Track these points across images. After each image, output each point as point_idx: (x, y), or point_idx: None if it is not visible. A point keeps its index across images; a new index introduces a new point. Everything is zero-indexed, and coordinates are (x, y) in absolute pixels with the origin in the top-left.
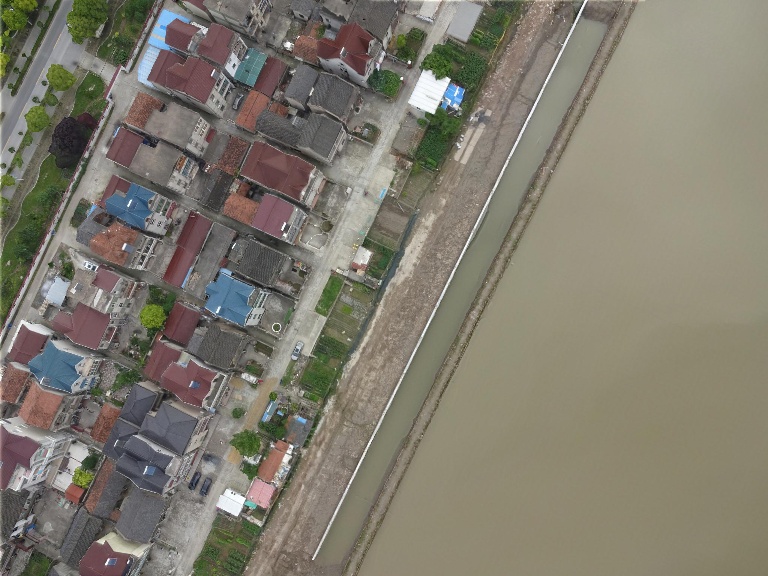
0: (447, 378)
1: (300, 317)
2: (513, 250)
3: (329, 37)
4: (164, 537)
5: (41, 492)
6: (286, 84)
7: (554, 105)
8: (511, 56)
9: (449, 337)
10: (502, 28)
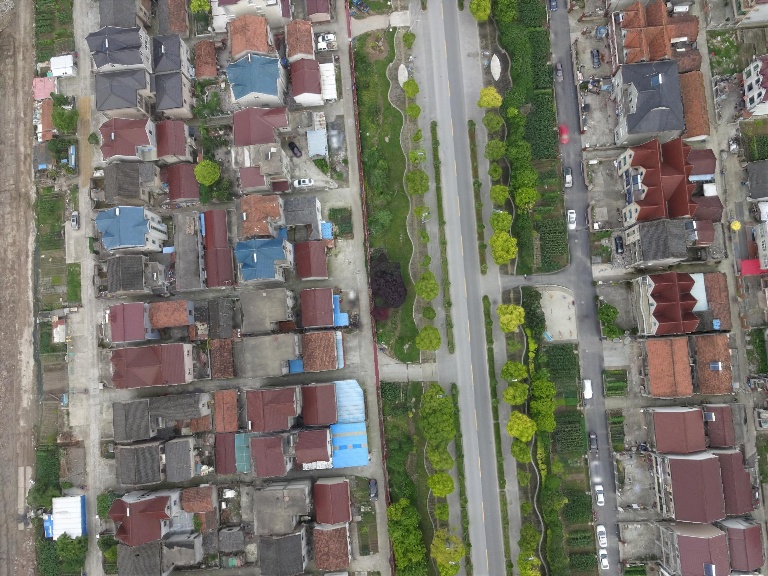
0: None
1: None
2: None
3: (187, 522)
4: None
5: None
6: None
7: None
8: None
9: None
10: None
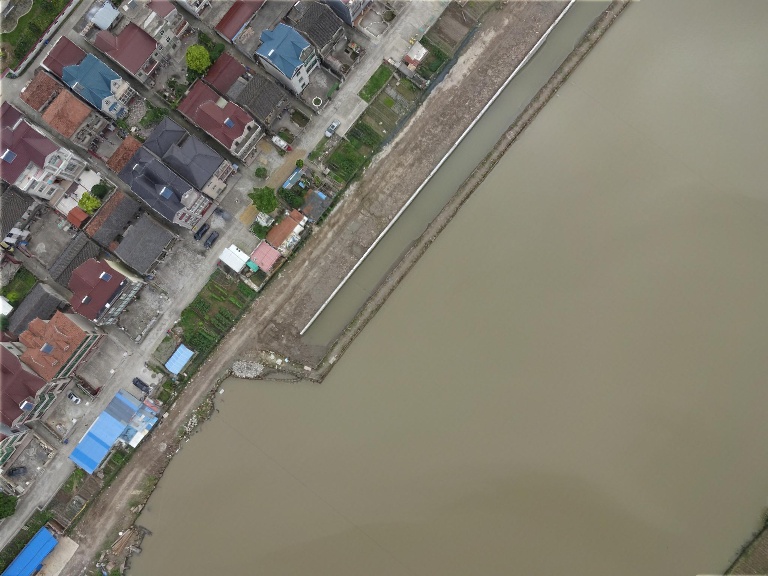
0: (471, 189)
1: (342, 97)
2: (562, 82)
3: None
4: (158, 280)
5: (43, 209)
6: None
7: None
8: None
9: (480, 155)
10: None
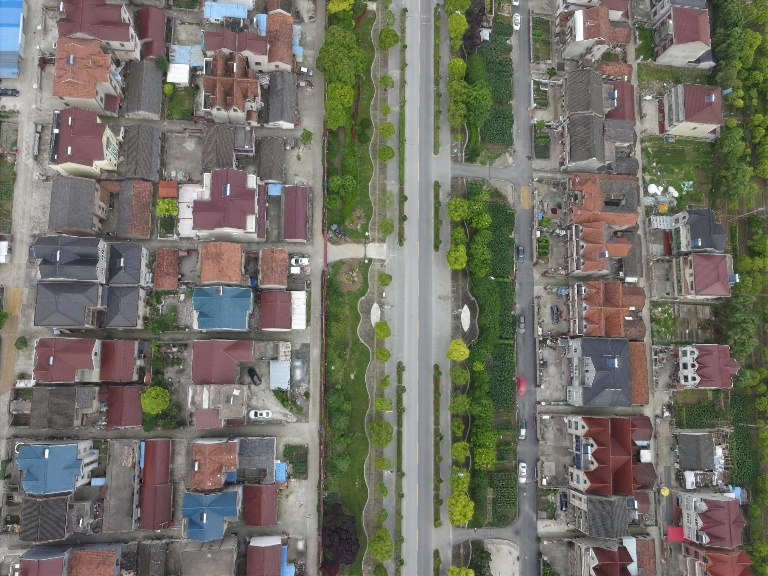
0: None
1: None
2: None
3: None
4: None
5: None
6: None
7: None
8: None
9: None
10: None
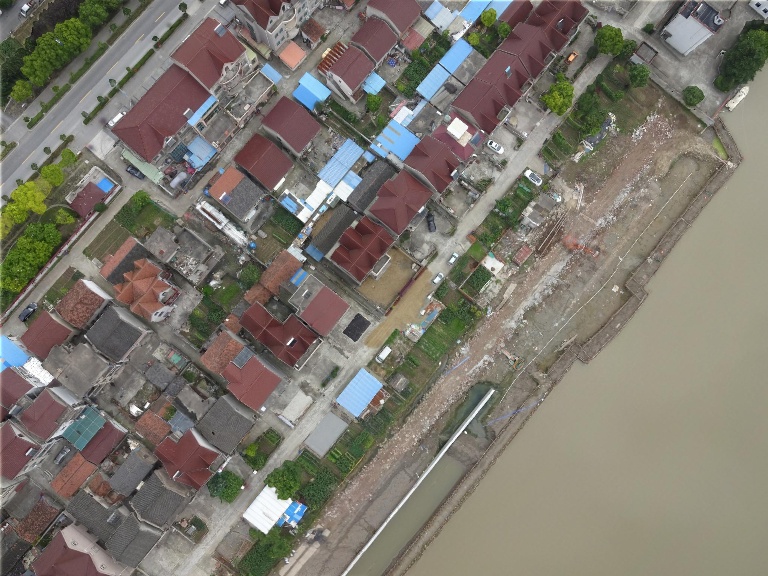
0: None
1: None
2: None
3: (178, 420)
4: None
5: None
6: (121, 449)
7: (395, 535)
8: (364, 479)
9: None
10: (362, 450)
